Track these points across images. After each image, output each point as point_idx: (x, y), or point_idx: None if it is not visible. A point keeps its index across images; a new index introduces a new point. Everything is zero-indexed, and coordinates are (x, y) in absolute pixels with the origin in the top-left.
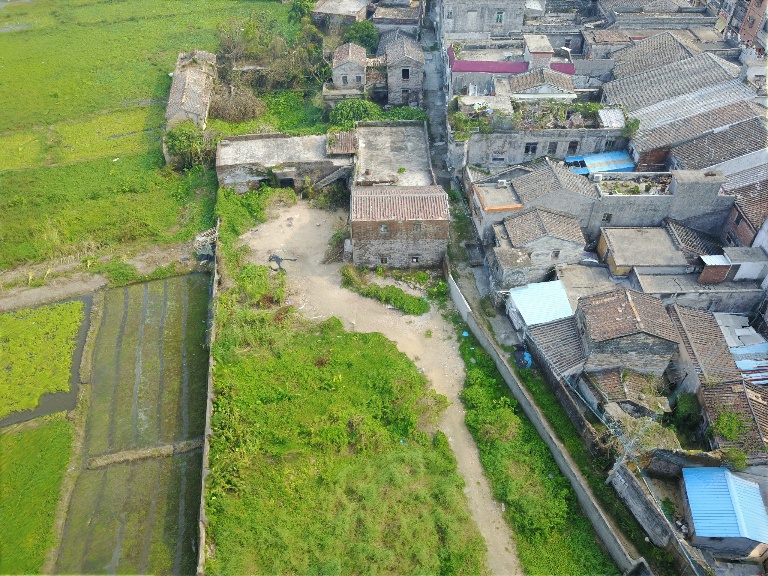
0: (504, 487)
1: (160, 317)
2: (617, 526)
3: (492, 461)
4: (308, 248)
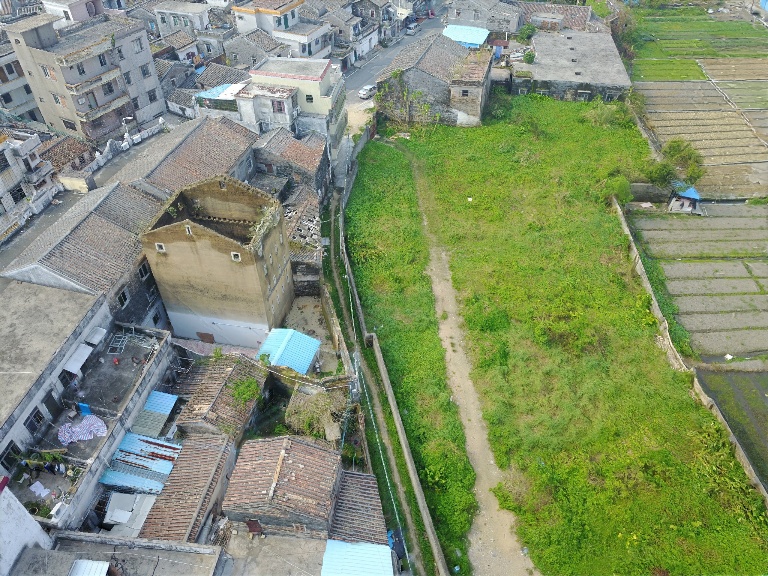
0: (449, 407)
1: None
2: (365, 376)
3: (456, 429)
4: None
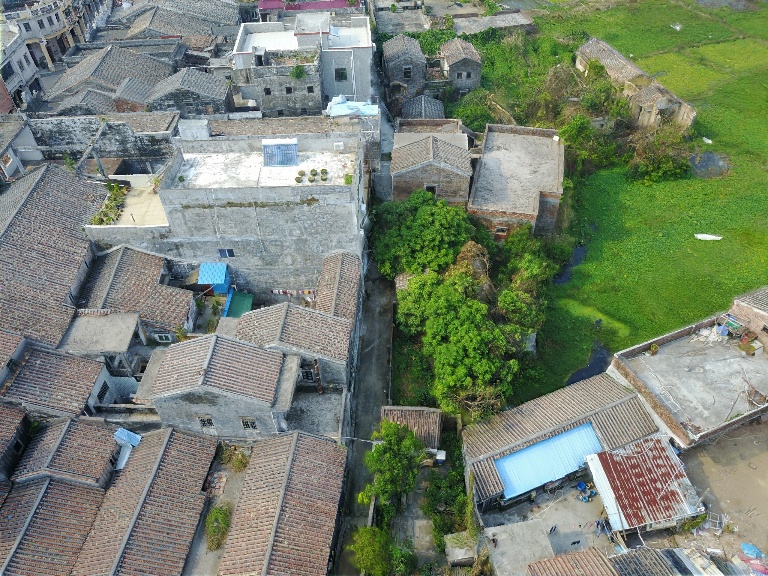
0: None
1: (507, 3)
2: None
3: None
4: (443, 10)
